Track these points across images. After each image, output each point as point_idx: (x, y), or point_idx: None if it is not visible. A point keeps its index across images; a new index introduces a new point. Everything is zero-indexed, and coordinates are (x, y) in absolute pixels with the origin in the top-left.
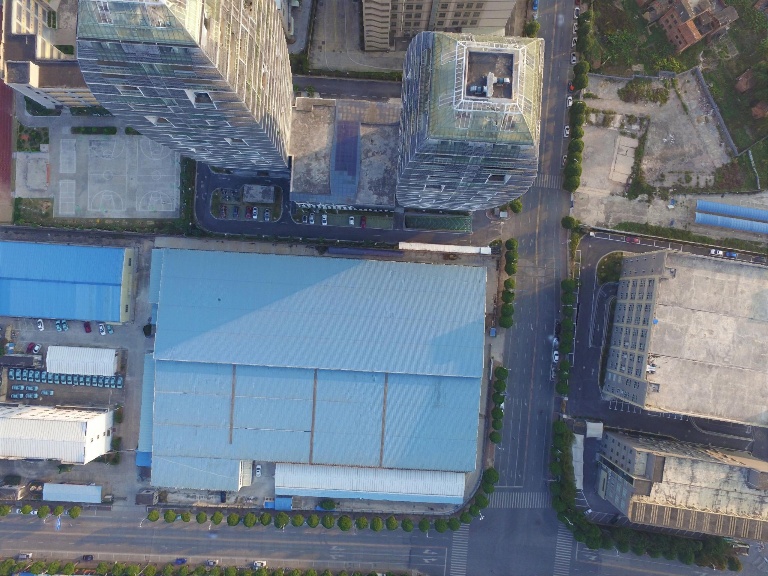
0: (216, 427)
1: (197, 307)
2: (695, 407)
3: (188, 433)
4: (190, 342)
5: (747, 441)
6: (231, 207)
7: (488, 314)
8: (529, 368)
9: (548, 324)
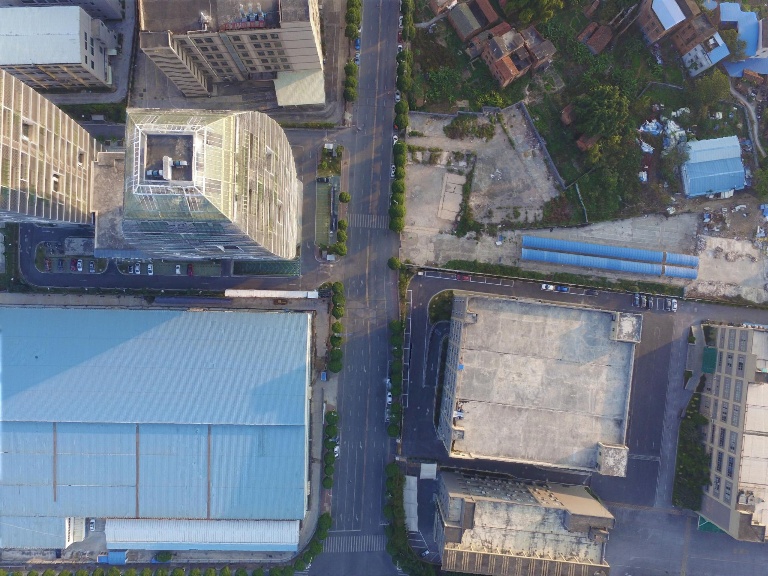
0: (39, 485)
1: (14, 366)
2: (505, 451)
3: (11, 492)
4: (7, 401)
5: (584, 475)
6: (56, 260)
7: (321, 358)
8: (363, 410)
9: (381, 365)
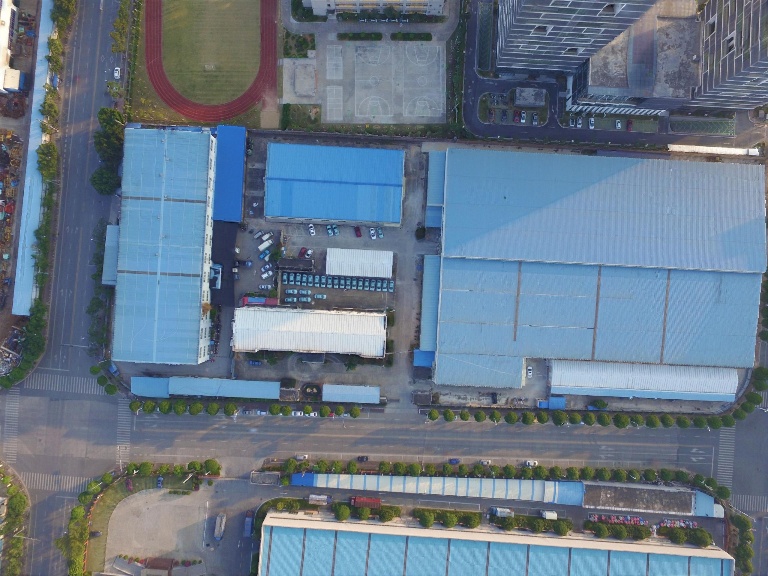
0: (501, 324)
1: (483, 205)
2: None
3: (473, 331)
4: (479, 239)
5: None
6: (498, 111)
7: None
8: None
9: None
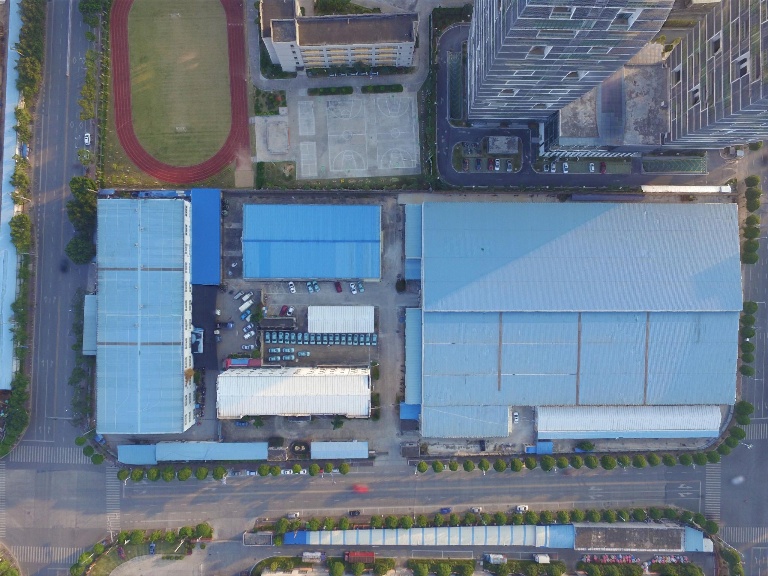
0: (485, 375)
1: (461, 258)
2: None
3: (457, 382)
4: (458, 292)
5: None
6: (473, 160)
7: None
8: None
9: None
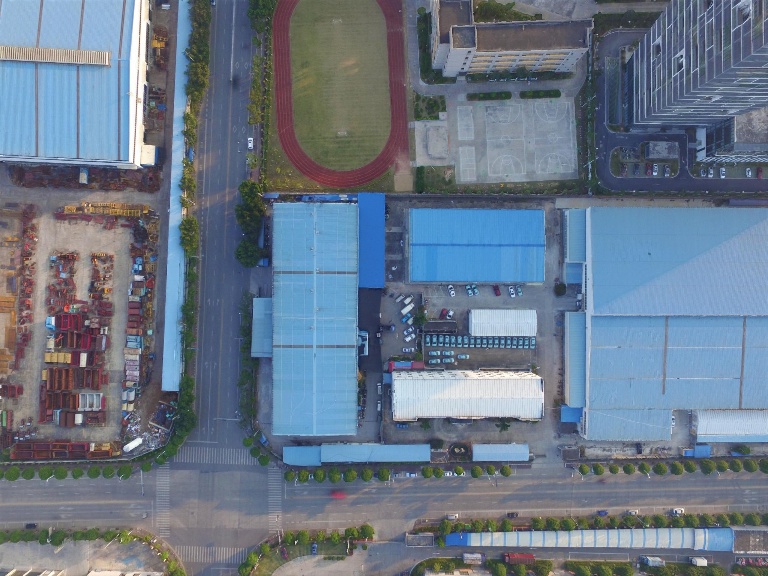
0: (649, 379)
1: (629, 262)
2: None
3: (623, 386)
4: (626, 296)
5: None
6: (630, 165)
7: None
8: None
9: None
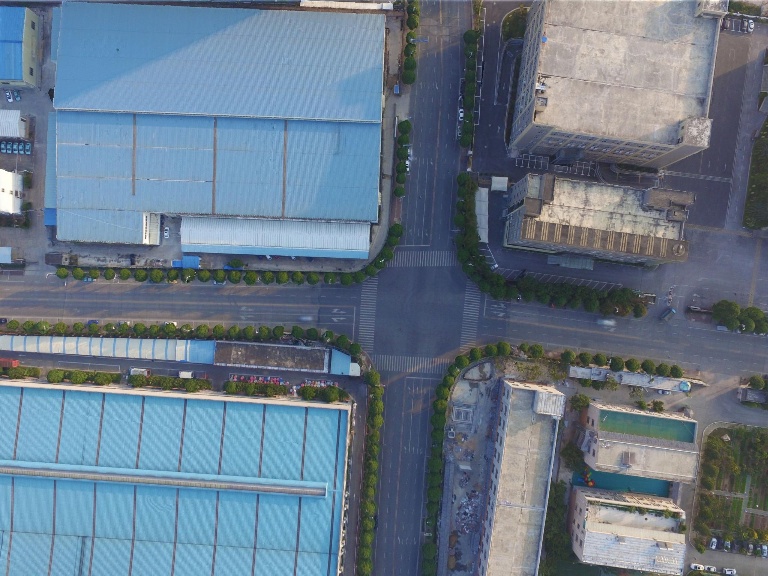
0: (119, 178)
1: (96, 57)
2: (586, 127)
3: (91, 185)
4: (89, 91)
5: None
6: None
7: (393, 75)
8: (435, 127)
9: (453, 83)
